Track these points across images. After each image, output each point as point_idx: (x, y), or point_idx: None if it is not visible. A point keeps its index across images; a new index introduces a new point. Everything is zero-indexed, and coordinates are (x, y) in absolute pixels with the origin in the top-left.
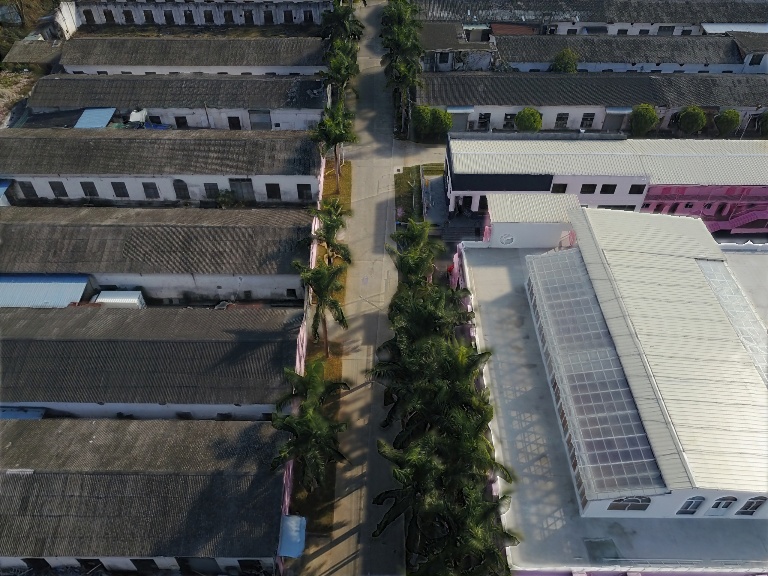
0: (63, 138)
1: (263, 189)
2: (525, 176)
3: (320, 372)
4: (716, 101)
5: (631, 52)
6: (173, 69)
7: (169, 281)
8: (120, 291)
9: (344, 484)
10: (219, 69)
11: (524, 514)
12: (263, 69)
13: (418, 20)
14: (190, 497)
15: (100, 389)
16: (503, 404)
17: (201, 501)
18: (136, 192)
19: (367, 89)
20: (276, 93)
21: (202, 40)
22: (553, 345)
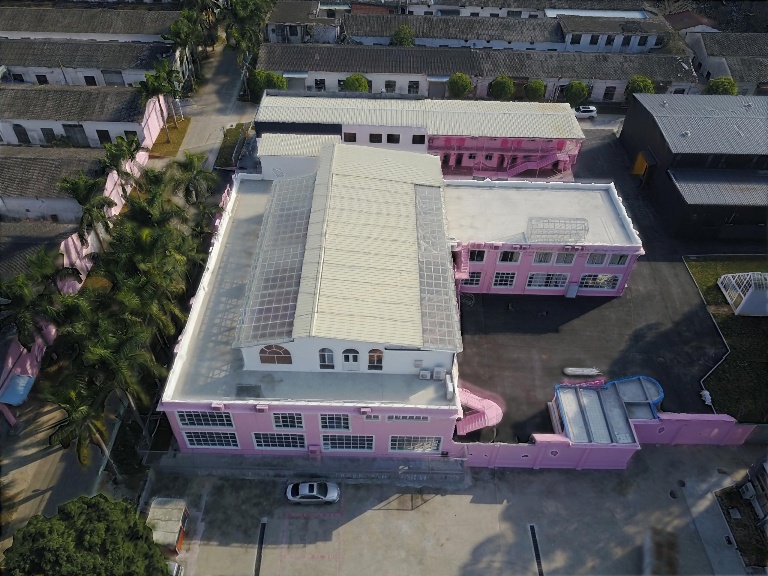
0: None
1: (95, 135)
2: (317, 125)
3: (58, 260)
4: (526, 72)
5: (465, 30)
6: (46, 35)
7: None
8: None
9: None
10: (88, 36)
11: (197, 367)
12: (128, 37)
13: None
14: None
15: None
16: (218, 292)
17: None
18: None
19: (228, 59)
20: (128, 56)
21: (75, 10)
22: (261, 244)
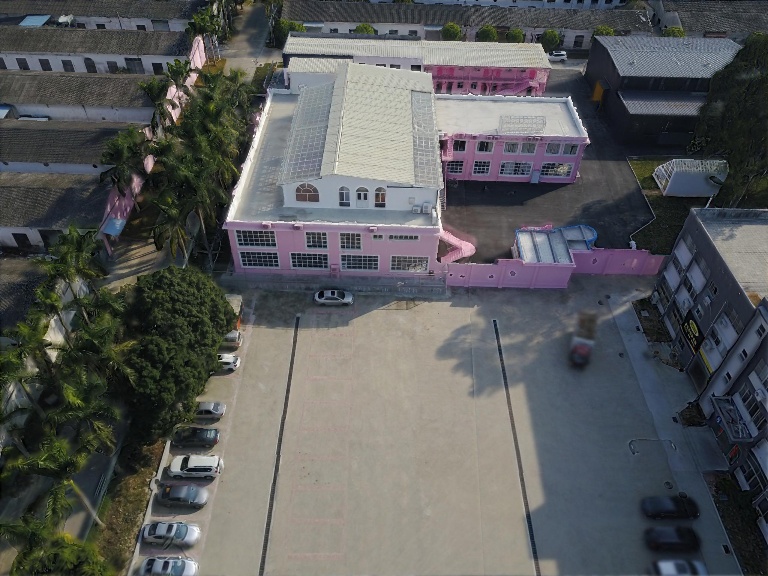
0: (5, 28)
1: (150, 67)
2: (333, 56)
3: (142, 136)
4: (508, 23)
5: None
6: None
7: (68, 112)
8: (33, 118)
9: (163, 220)
10: None
11: (249, 205)
12: None
13: None
14: (51, 199)
15: (6, 154)
16: (261, 163)
17: (58, 202)
18: (57, 68)
19: (254, 15)
20: (174, 8)
21: None
22: (294, 126)
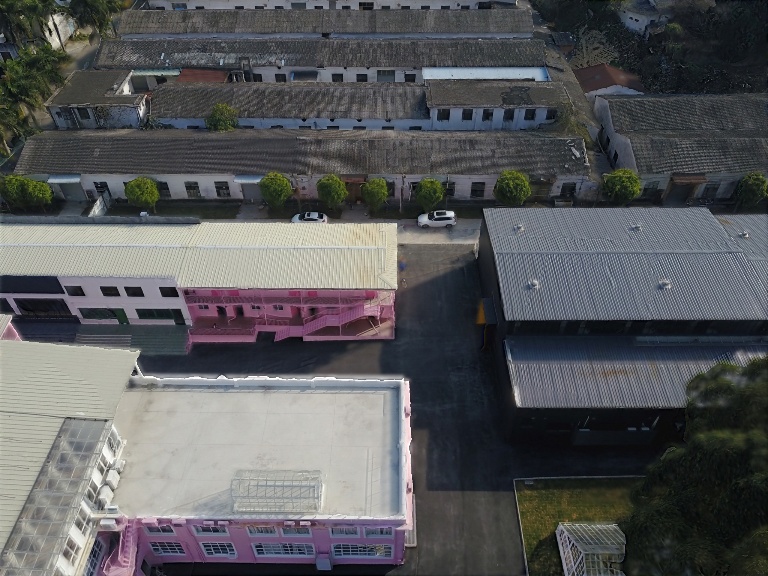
0: None
1: None
2: (23, 278)
3: None
4: (365, 168)
5: (303, 105)
6: None
7: None
8: None
9: None
10: None
11: None
12: None
13: (102, 65)
14: None
15: None
16: None
17: None
18: None
19: (12, 147)
20: None
21: None
22: None
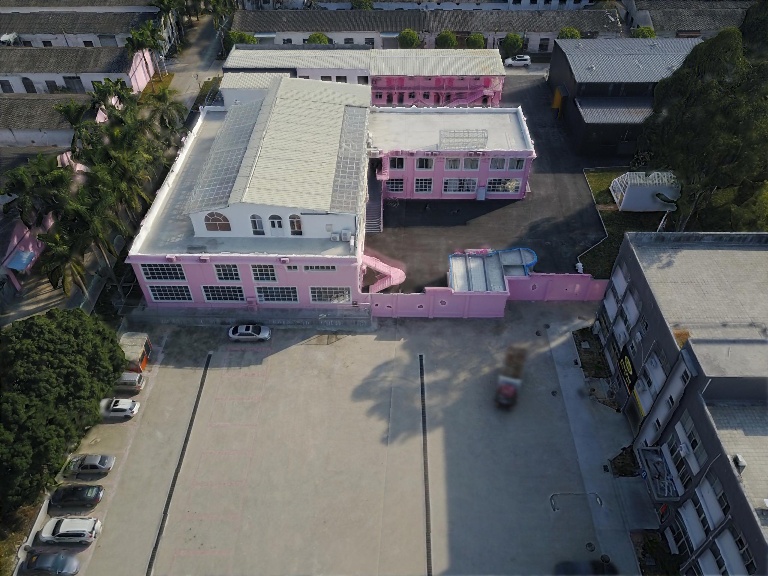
0: None
1: (90, 86)
2: (275, 69)
3: (53, 163)
4: (468, 27)
5: None
6: (52, 10)
7: None
8: None
9: None
10: (88, 9)
11: (158, 236)
12: (123, 9)
13: None
14: None
15: None
16: (180, 188)
17: None
18: None
19: (210, 27)
20: (121, 22)
21: None
22: (214, 148)
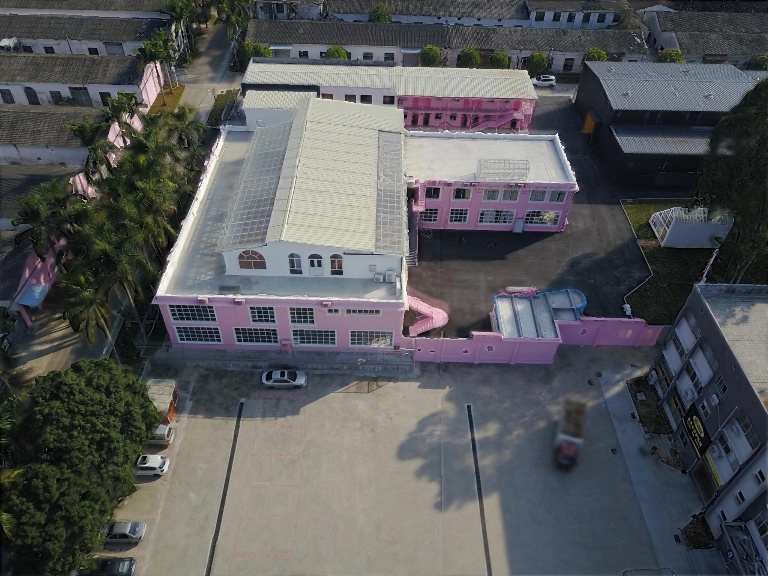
0: None
1: (98, 97)
2: (297, 86)
3: (68, 188)
4: (492, 45)
5: (438, 8)
6: (53, 12)
7: None
8: None
9: None
10: (91, 13)
11: (186, 273)
12: (128, 14)
13: None
14: None
15: None
16: (205, 218)
17: None
18: None
19: (220, 35)
20: (128, 29)
21: None
22: (243, 176)
